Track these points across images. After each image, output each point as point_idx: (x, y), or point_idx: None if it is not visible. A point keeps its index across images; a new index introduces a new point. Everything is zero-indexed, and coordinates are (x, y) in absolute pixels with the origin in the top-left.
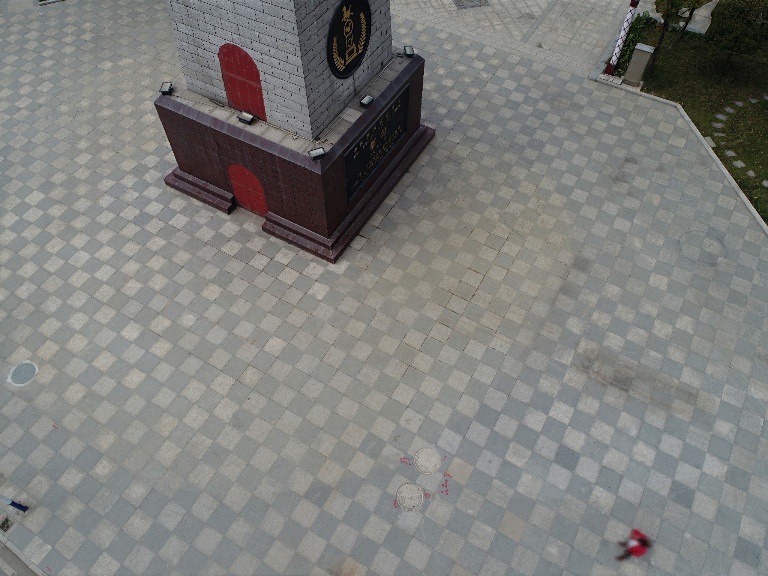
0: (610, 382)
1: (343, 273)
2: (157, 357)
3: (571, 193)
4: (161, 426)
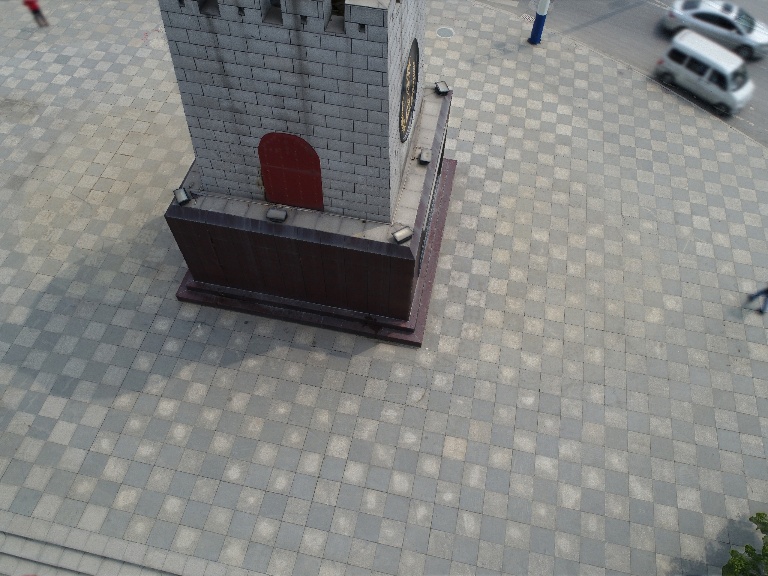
0: (18, 102)
1: None
2: None
3: (7, 257)
4: None
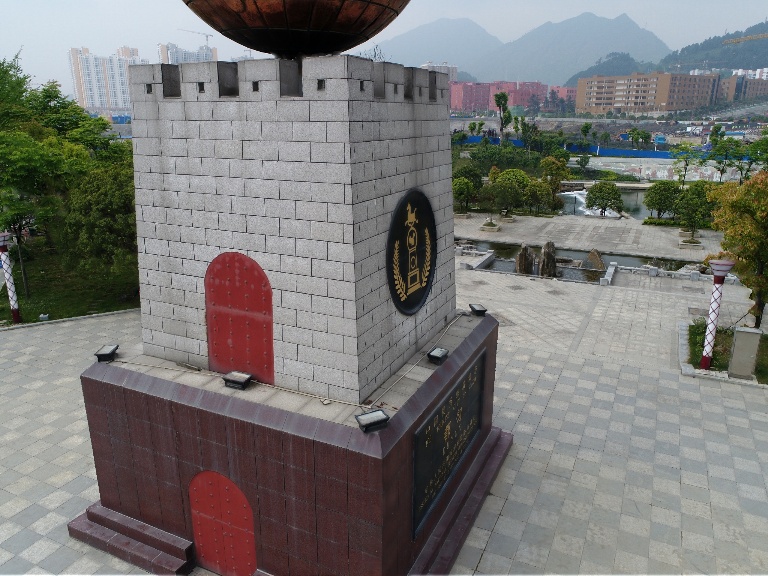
0: None
1: None
2: None
3: None
4: None
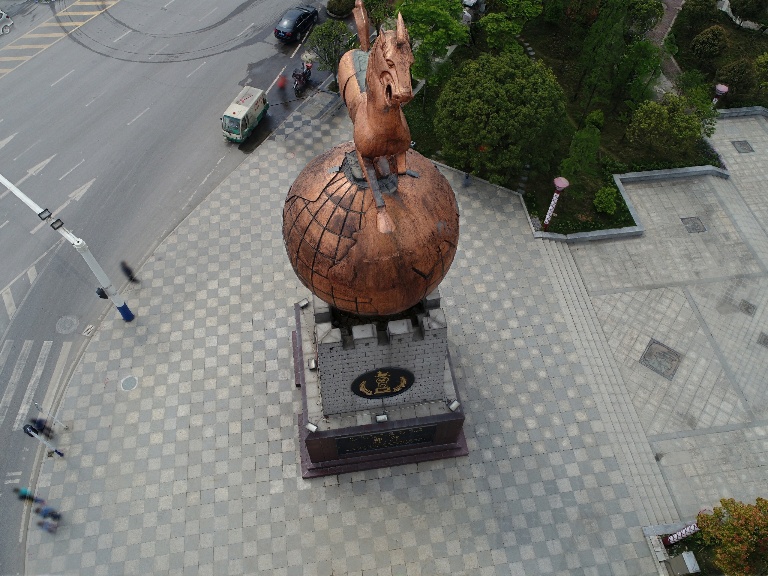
0: None
1: (300, 490)
2: (176, 438)
3: None
4: (137, 478)
